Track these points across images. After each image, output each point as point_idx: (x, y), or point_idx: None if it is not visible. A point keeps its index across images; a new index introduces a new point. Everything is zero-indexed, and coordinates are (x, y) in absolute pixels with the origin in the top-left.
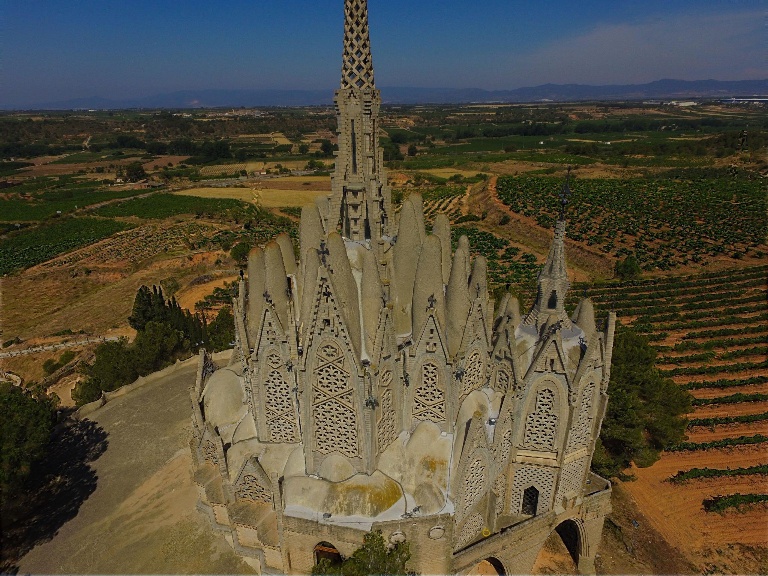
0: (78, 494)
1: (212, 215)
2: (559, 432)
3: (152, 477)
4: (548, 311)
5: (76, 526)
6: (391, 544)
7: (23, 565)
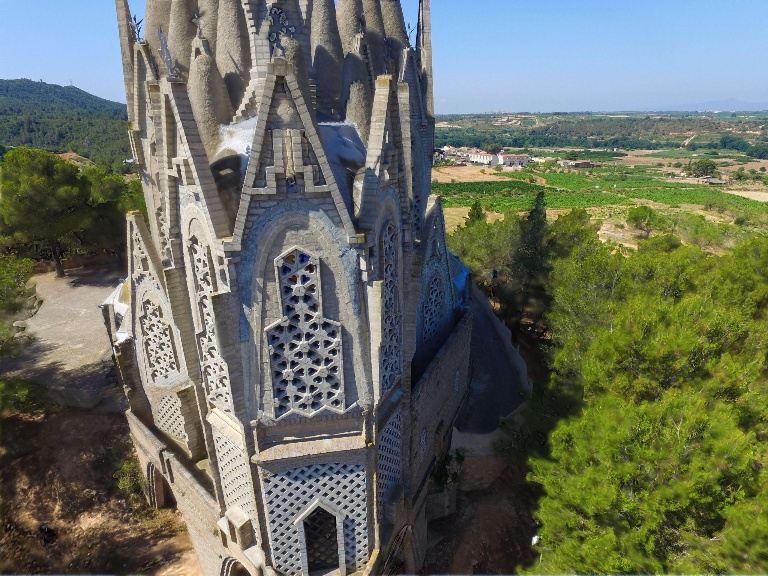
0: None
1: (722, 209)
2: None
3: None
4: None
5: None
6: None
7: None
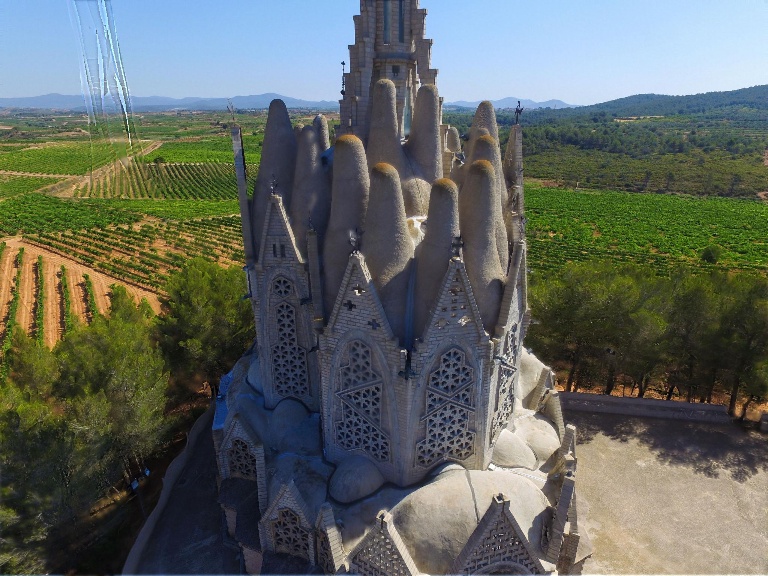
0: None
1: None
2: None
3: None
4: None
5: None
6: None
7: None
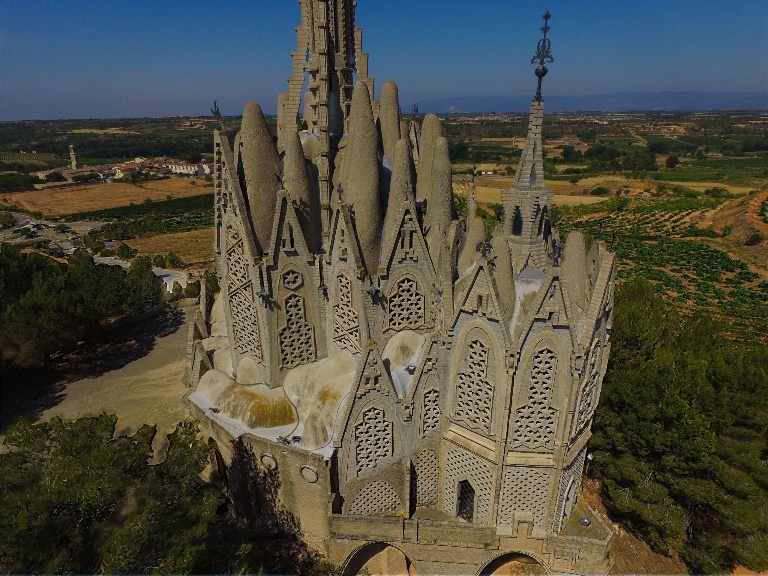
0: (134, 355)
1: None
2: (496, 411)
3: (184, 360)
4: (511, 237)
5: (115, 375)
6: (264, 466)
7: (70, 387)
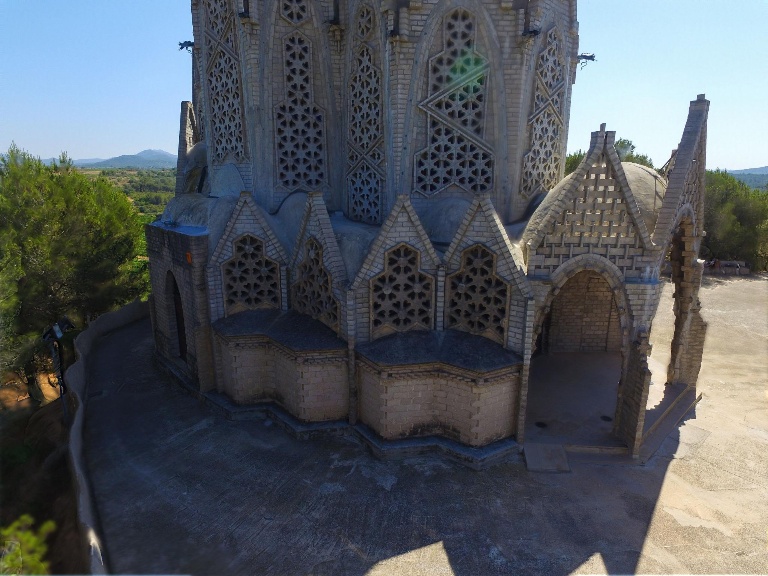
0: None
1: None
2: None
3: None
4: None
5: None
6: None
7: None
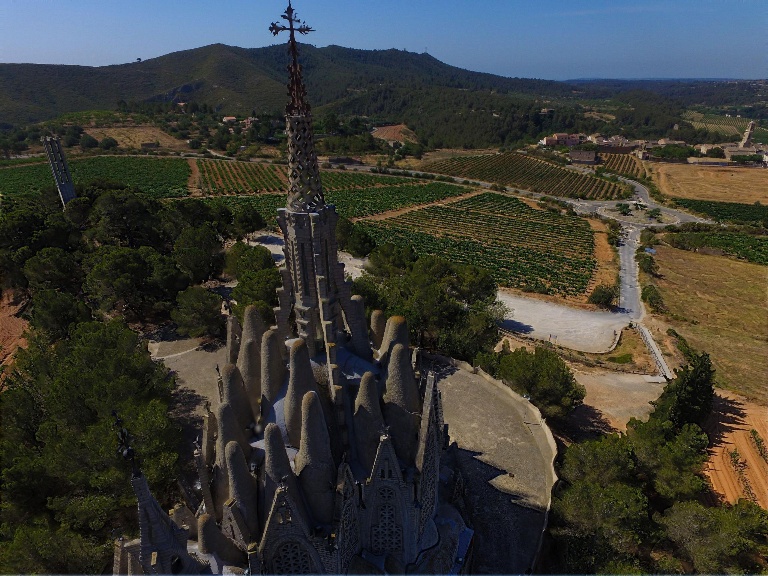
0: None
1: None
2: None
3: None
4: None
5: None
6: None
7: None
